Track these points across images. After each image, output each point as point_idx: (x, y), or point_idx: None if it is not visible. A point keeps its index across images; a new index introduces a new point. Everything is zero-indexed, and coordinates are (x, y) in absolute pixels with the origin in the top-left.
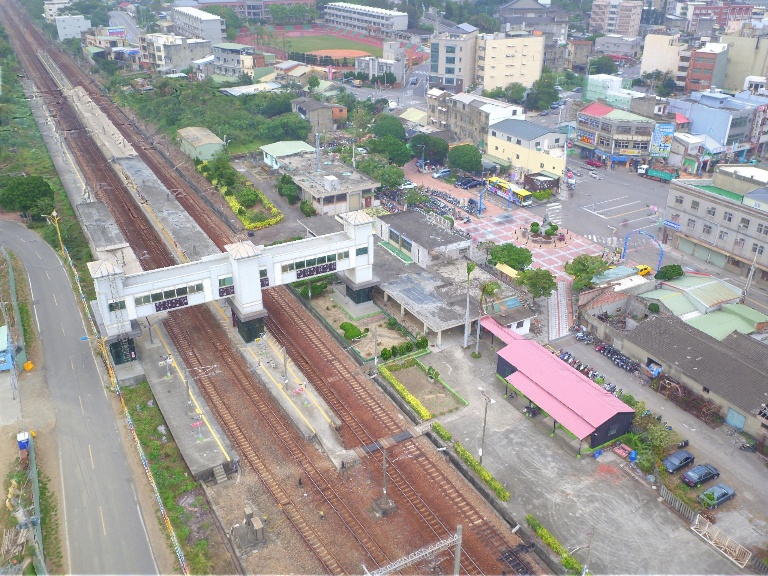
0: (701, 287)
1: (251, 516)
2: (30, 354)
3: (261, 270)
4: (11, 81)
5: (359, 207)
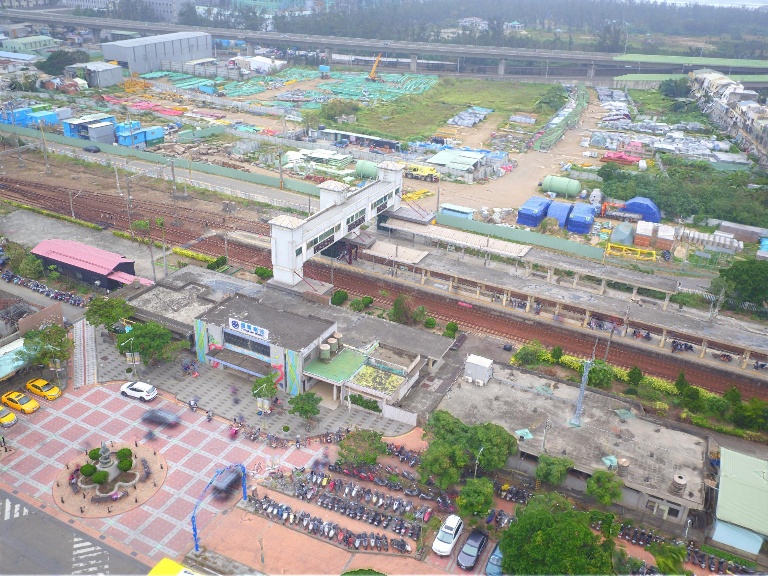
0: None
1: None
2: (449, 227)
3: None
4: None
5: None
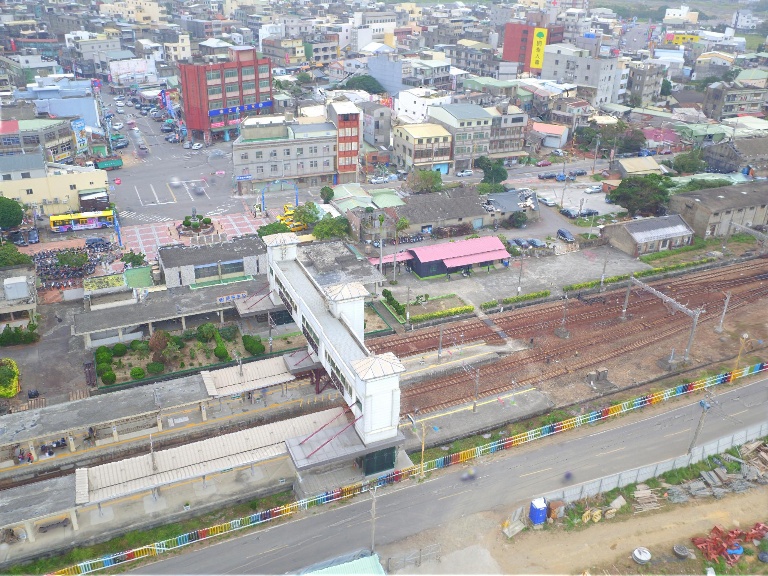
0: (350, 191)
1: None
2: None
3: None
4: None
5: None
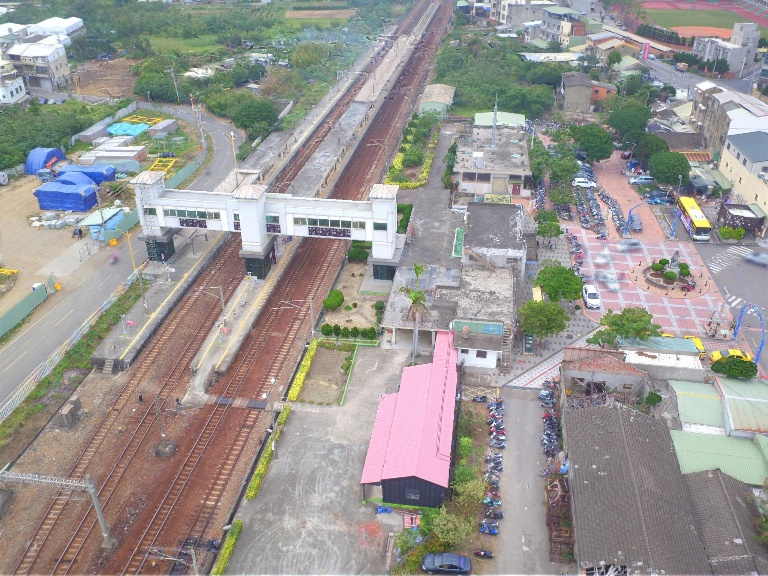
0: (756, 402)
1: (74, 403)
2: None
3: (274, 216)
4: (376, 25)
5: (504, 192)
